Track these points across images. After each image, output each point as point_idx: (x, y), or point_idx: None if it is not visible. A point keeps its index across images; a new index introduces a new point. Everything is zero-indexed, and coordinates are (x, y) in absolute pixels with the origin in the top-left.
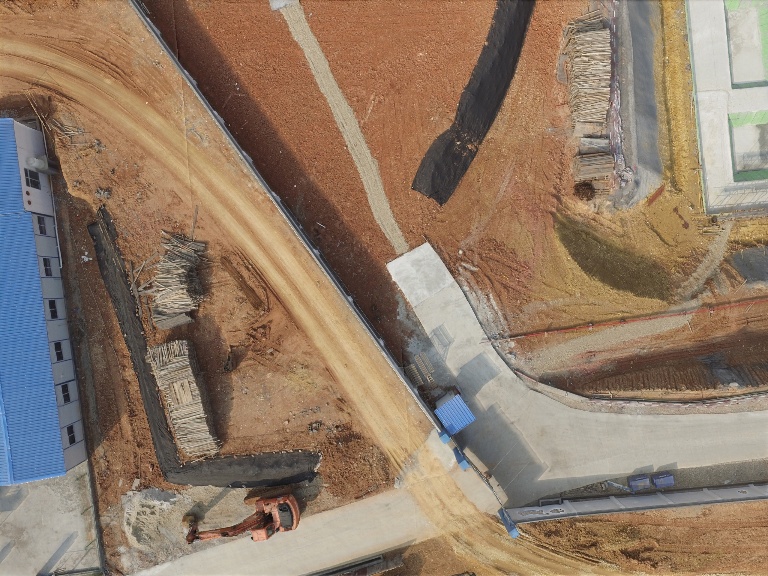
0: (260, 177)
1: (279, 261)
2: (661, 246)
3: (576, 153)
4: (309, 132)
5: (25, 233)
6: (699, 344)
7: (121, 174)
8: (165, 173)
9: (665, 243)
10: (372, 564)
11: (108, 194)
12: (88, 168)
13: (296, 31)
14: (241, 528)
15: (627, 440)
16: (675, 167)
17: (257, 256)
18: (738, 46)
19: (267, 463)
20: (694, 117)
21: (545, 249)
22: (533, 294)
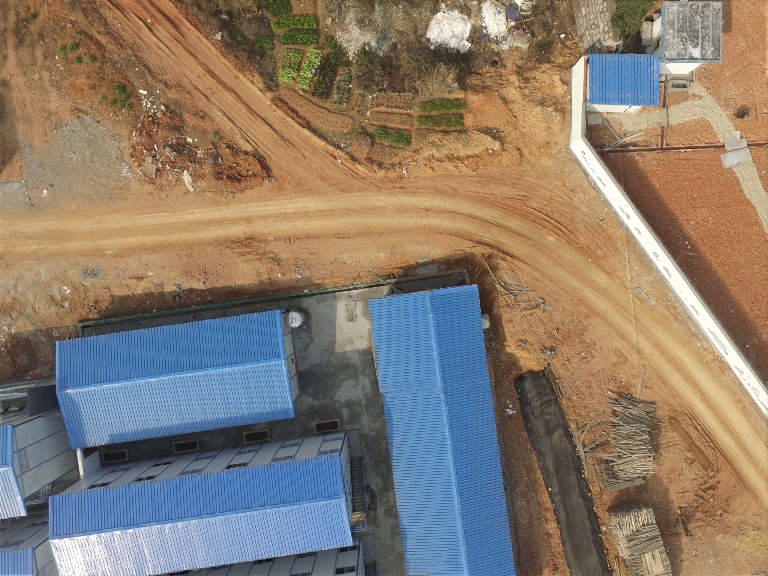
0: (736, 346)
1: (728, 421)
2: None
3: None
4: (762, 291)
5: (485, 399)
6: None
7: (565, 333)
8: (610, 332)
9: None
10: None
11: (554, 354)
12: (532, 327)
13: (748, 189)
14: None
15: None
16: None
17: (705, 416)
18: None
19: None
20: None
21: None
22: None
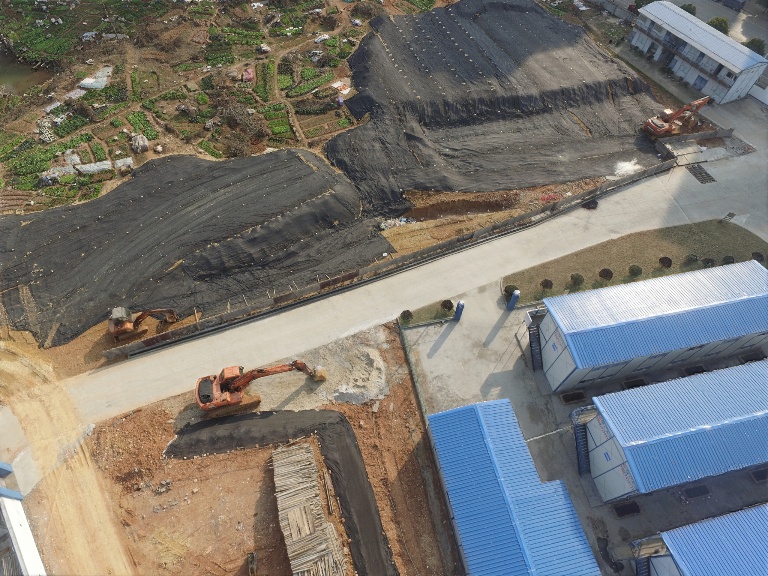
0: None
1: None
2: None
3: None
4: None
5: None
6: None
7: None
8: None
9: None
10: (140, 350)
11: None
12: None
13: None
14: (246, 378)
15: None
16: None
17: None
18: None
19: (224, 442)
20: None
21: None
22: None
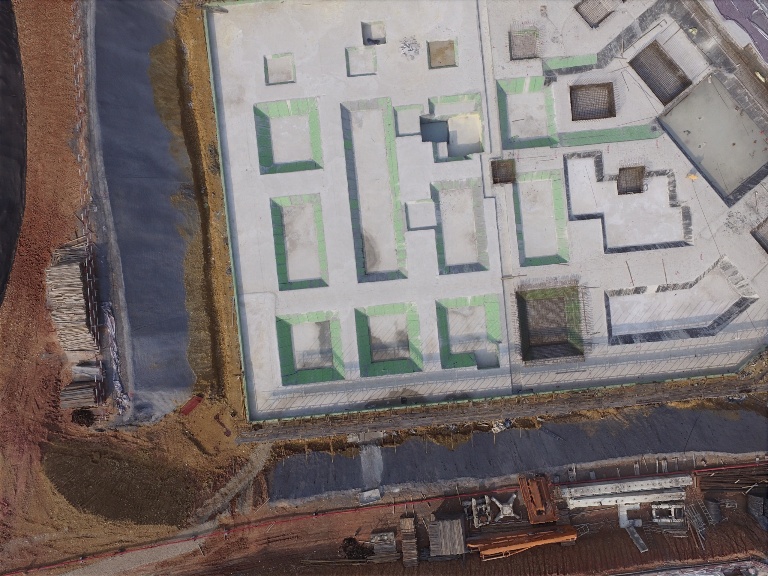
0: None
1: None
2: (198, 456)
3: (73, 379)
4: None
5: None
6: (212, 568)
7: None
8: None
9: (204, 452)
10: None
11: None
12: None
13: None
14: None
15: None
16: (224, 370)
17: None
18: (294, 243)
19: None
20: (236, 322)
21: (29, 484)
22: (14, 531)
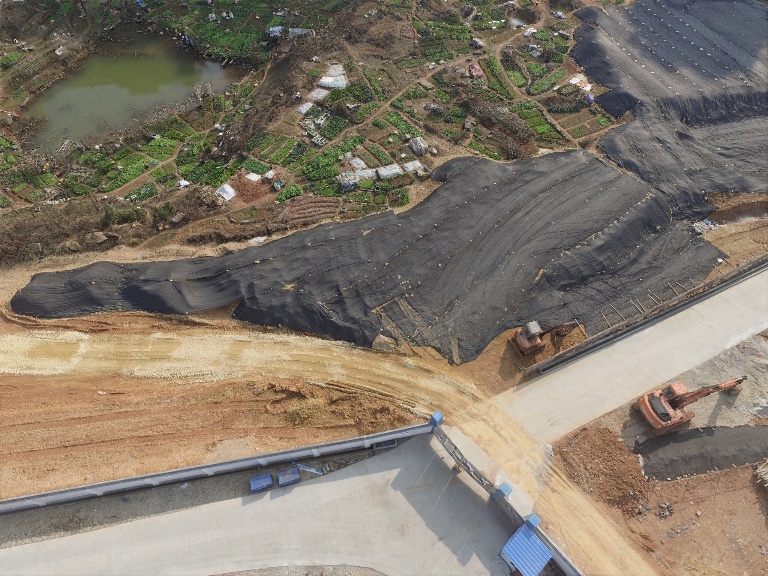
0: None
1: None
2: None
3: None
4: None
5: None
6: None
7: None
8: None
9: None
10: (548, 365)
11: None
12: None
13: None
14: (703, 395)
15: (301, 529)
16: None
17: None
18: None
19: (697, 461)
20: None
21: None
22: None
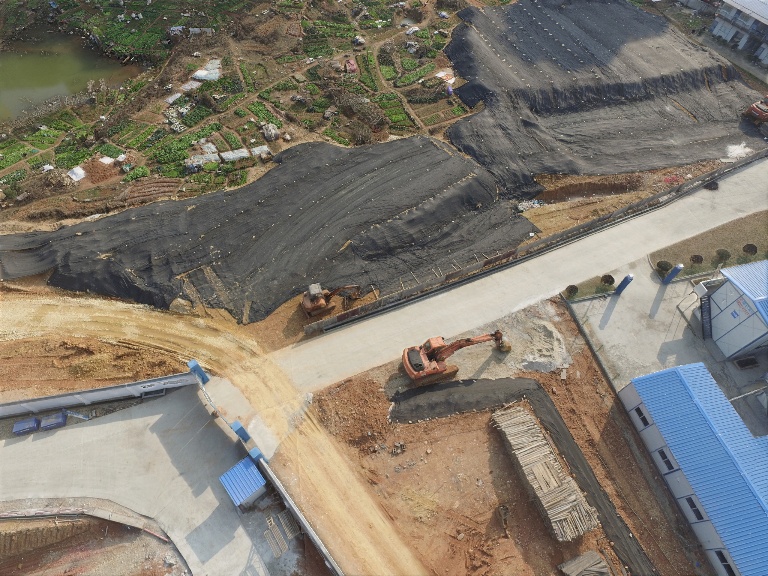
0: None
1: None
2: None
3: None
4: None
5: None
6: None
7: None
8: None
9: None
10: (333, 325)
11: None
12: None
13: None
14: (454, 347)
15: (53, 467)
16: None
17: None
18: None
19: (442, 407)
20: None
21: None
22: None
